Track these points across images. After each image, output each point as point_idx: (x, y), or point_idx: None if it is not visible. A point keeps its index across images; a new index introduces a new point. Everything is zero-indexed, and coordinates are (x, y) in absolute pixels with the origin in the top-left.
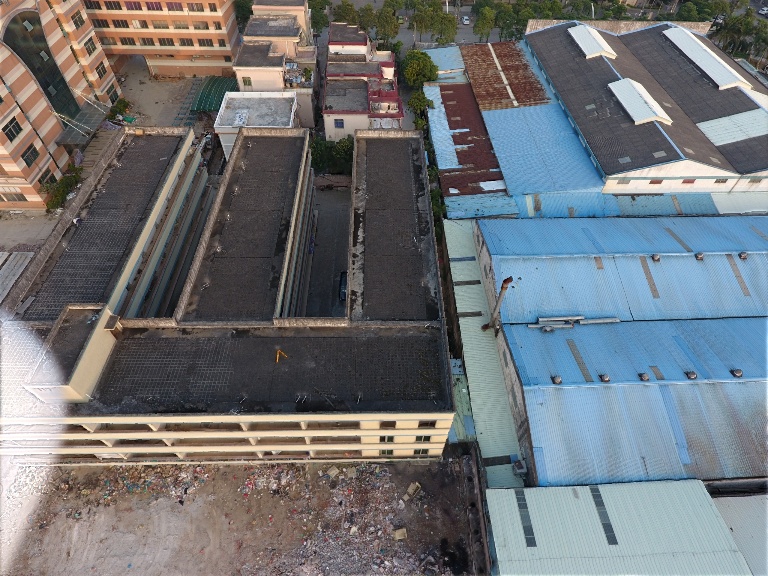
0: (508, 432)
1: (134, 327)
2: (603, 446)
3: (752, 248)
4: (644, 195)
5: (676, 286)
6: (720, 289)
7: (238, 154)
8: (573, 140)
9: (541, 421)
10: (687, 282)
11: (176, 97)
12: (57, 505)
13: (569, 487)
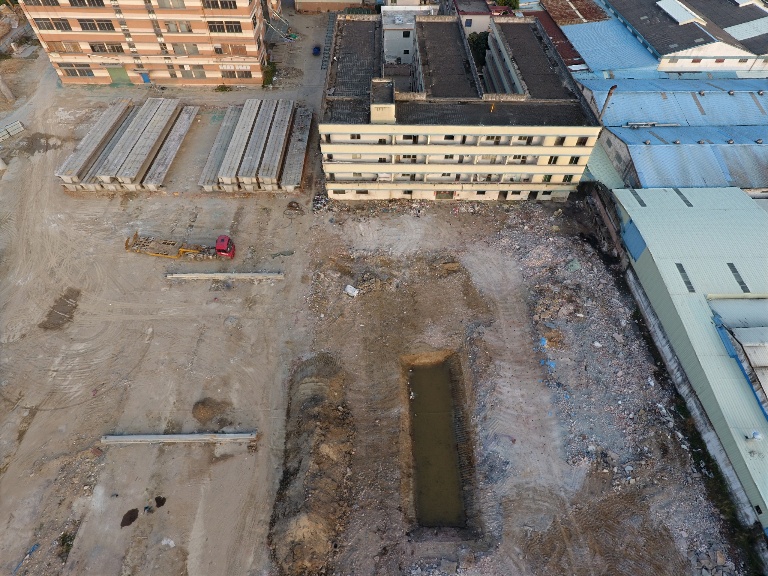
0: (615, 179)
1: (400, 100)
2: (679, 172)
3: (767, 90)
4: (687, 72)
5: (716, 108)
6: (746, 110)
7: (417, 30)
8: (633, 39)
9: (640, 160)
10: (724, 106)
11: (320, 24)
12: (344, 216)
13: (661, 188)
